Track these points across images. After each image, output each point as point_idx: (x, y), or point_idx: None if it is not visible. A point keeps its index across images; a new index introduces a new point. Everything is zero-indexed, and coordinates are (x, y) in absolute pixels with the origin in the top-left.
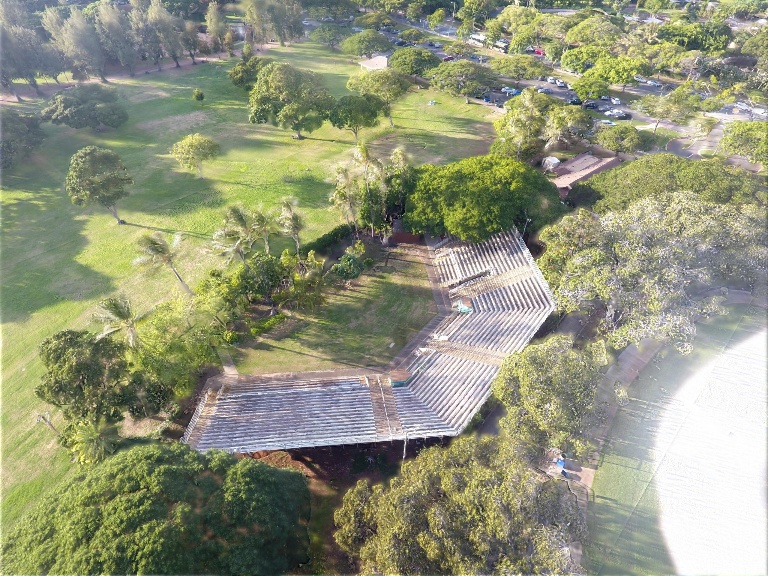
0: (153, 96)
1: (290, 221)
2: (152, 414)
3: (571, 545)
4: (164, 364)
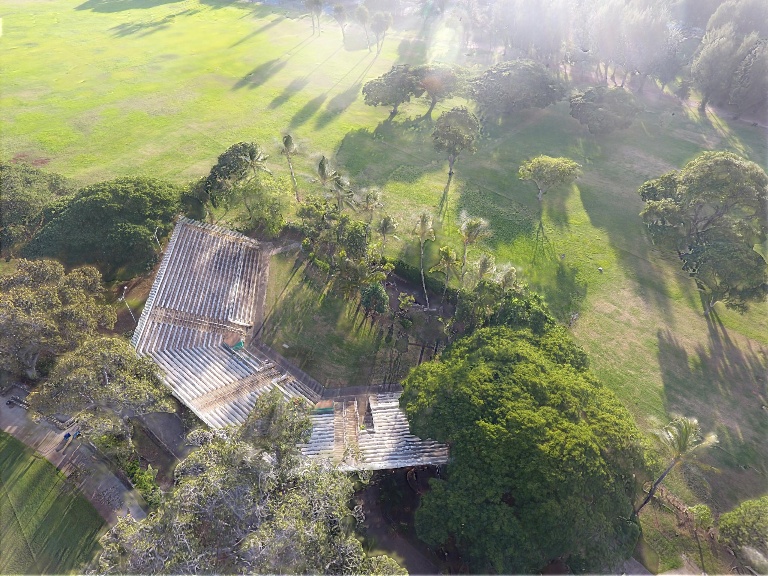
0: (699, 140)
1: (383, 220)
2: (213, 205)
3: (14, 425)
4: (236, 193)
